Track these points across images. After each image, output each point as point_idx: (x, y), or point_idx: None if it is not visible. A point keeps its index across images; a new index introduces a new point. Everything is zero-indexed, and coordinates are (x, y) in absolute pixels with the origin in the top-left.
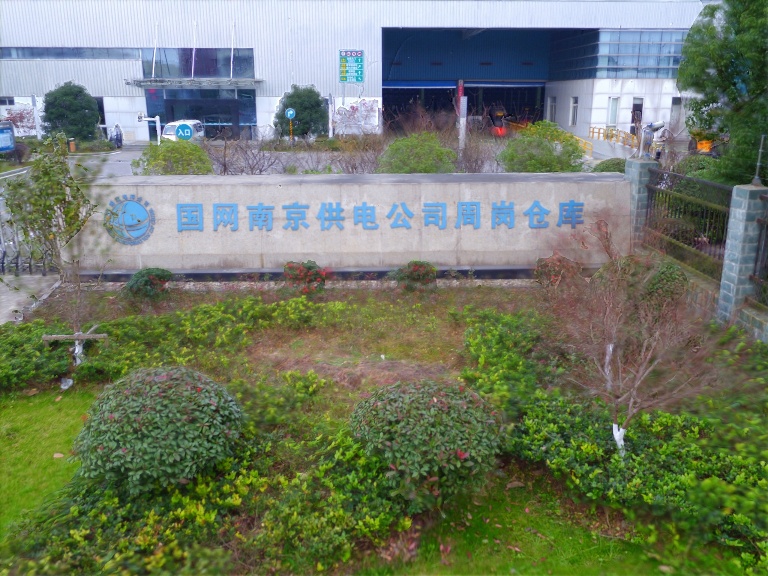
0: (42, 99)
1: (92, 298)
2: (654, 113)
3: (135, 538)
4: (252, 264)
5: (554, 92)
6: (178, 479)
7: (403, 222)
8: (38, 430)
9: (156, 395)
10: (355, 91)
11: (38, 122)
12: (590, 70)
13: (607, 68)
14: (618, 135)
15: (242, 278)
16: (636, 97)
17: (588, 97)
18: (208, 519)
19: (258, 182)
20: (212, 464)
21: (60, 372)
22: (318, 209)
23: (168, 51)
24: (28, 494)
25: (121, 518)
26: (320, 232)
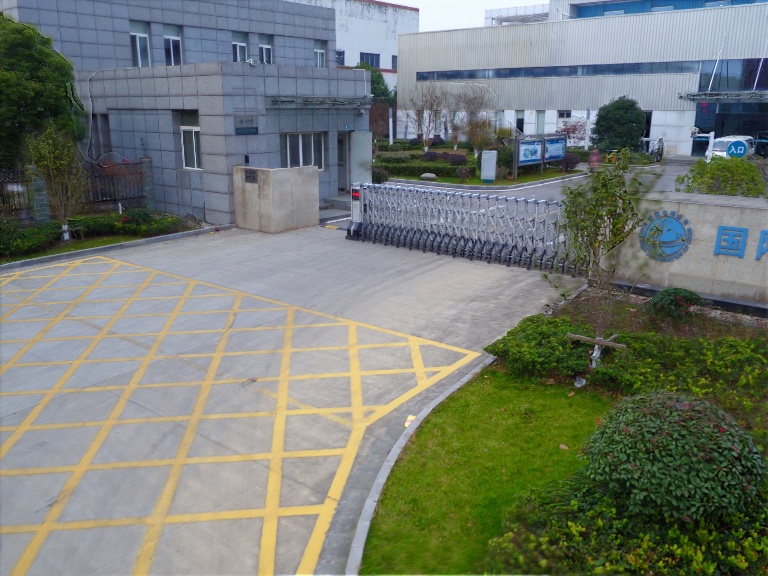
0: (596, 113)
1: (615, 307)
2: None
3: (627, 555)
4: None
5: None
6: (681, 515)
7: None
8: (550, 418)
9: (675, 422)
10: None
11: (588, 134)
12: None
13: None
14: None
15: None
16: None
17: None
18: (706, 569)
19: None
20: (719, 512)
21: (577, 370)
22: None
23: (731, 63)
24: (534, 472)
25: (616, 530)
26: None
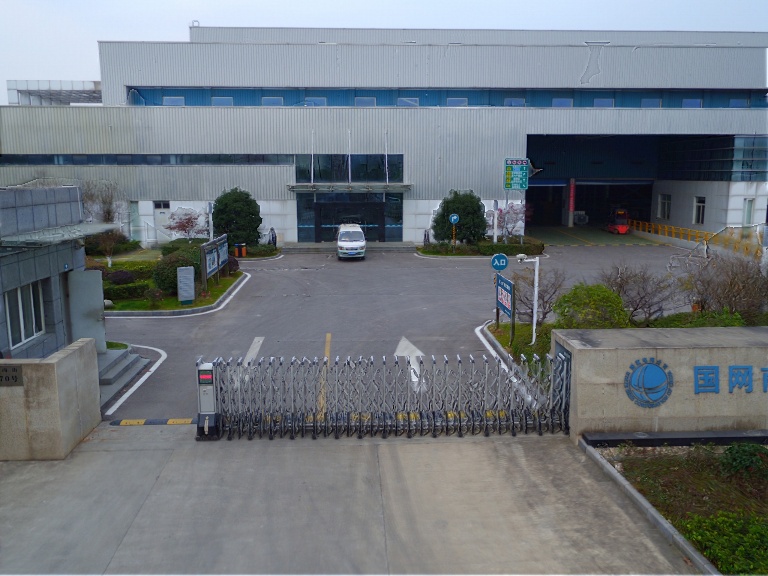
0: None
1: None
2: None
3: None
4: (764, 425)
5: (668, 190)
6: None
7: None
8: None
9: None
10: (499, 194)
11: (212, 228)
12: (722, 173)
13: (742, 171)
14: None
15: (766, 442)
16: None
17: (722, 198)
18: None
19: (760, 342)
20: None
21: None
22: None
23: (321, 157)
24: None
25: None
26: None
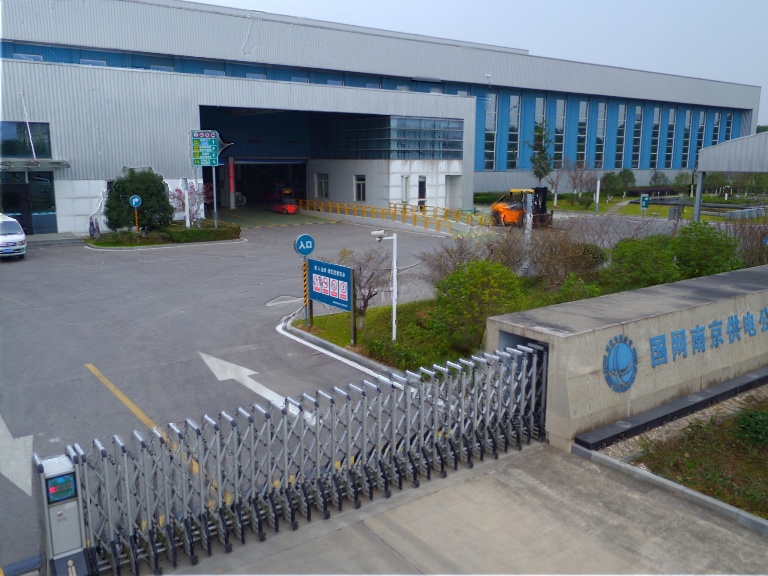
0: None
1: None
2: (434, 189)
3: None
4: (695, 388)
5: (325, 169)
6: None
7: (767, 325)
8: None
9: None
10: (174, 172)
11: None
12: (380, 151)
13: (398, 150)
14: (435, 211)
15: (707, 404)
16: (421, 176)
17: (382, 176)
18: None
19: (678, 304)
20: None
21: None
22: (726, 324)
23: None
24: None
25: None
26: (729, 345)
